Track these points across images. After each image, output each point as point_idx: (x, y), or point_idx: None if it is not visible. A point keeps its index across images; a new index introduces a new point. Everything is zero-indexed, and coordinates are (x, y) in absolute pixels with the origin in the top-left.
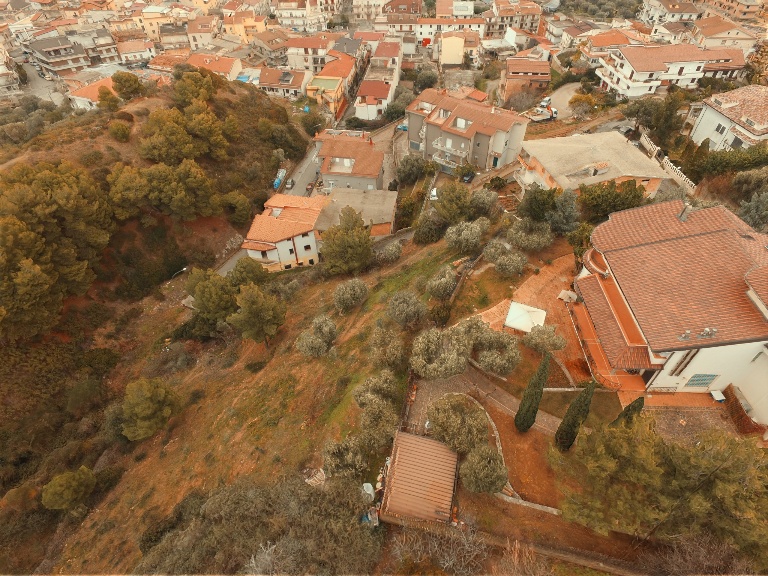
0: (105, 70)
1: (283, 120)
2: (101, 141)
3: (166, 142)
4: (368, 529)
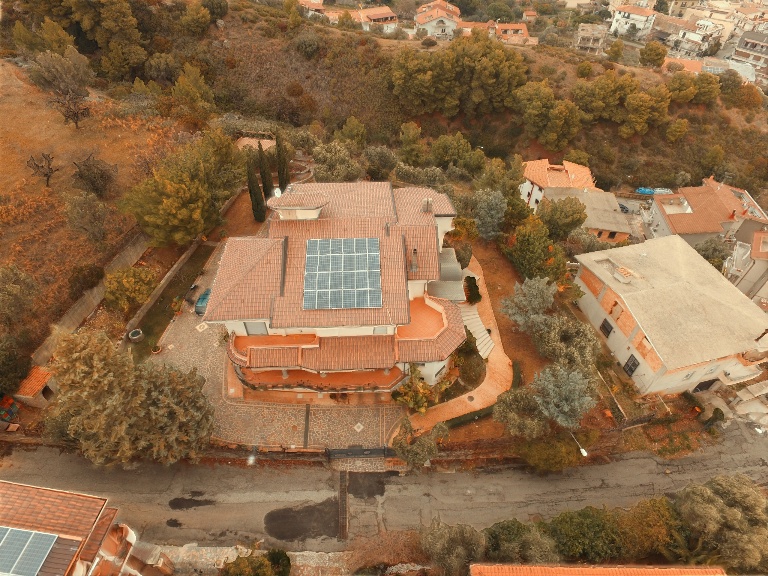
0: (737, 66)
1: (759, 173)
2: (567, 67)
3: (592, 91)
4: (234, 131)
